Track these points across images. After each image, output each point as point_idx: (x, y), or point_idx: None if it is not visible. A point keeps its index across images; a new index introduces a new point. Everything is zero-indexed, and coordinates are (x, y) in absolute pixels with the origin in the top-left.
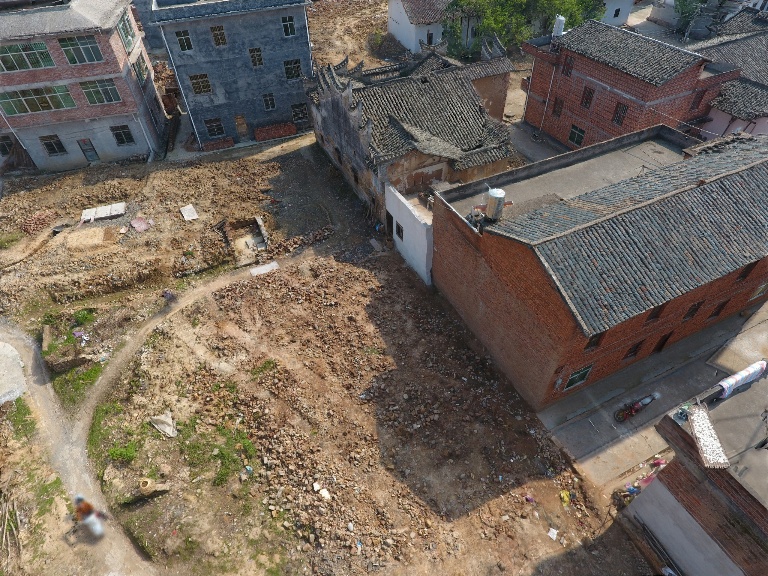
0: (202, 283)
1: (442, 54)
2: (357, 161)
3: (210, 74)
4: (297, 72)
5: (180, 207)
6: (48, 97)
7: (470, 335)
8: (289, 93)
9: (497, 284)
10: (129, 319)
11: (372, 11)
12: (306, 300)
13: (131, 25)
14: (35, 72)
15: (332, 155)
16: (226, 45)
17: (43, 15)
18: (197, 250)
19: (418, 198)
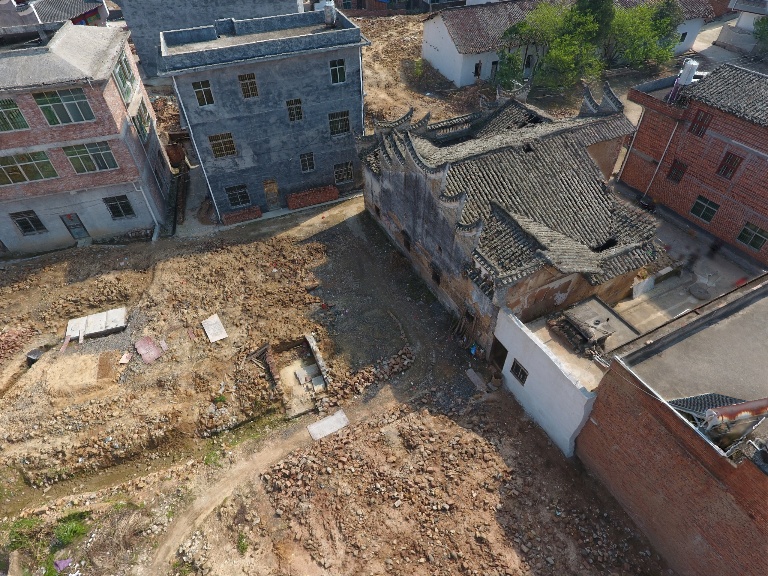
0: (242, 453)
1: (522, 101)
2: (443, 260)
3: (235, 133)
4: (344, 126)
5: (201, 319)
6: (20, 166)
7: (659, 561)
8: (332, 151)
9: (763, 545)
10: (140, 532)
11: (400, 32)
12: (405, 499)
13: (129, 66)
14: (2, 136)
15: (393, 235)
16: (257, 97)
17: (12, 61)
18: (230, 392)
19: (547, 328)
